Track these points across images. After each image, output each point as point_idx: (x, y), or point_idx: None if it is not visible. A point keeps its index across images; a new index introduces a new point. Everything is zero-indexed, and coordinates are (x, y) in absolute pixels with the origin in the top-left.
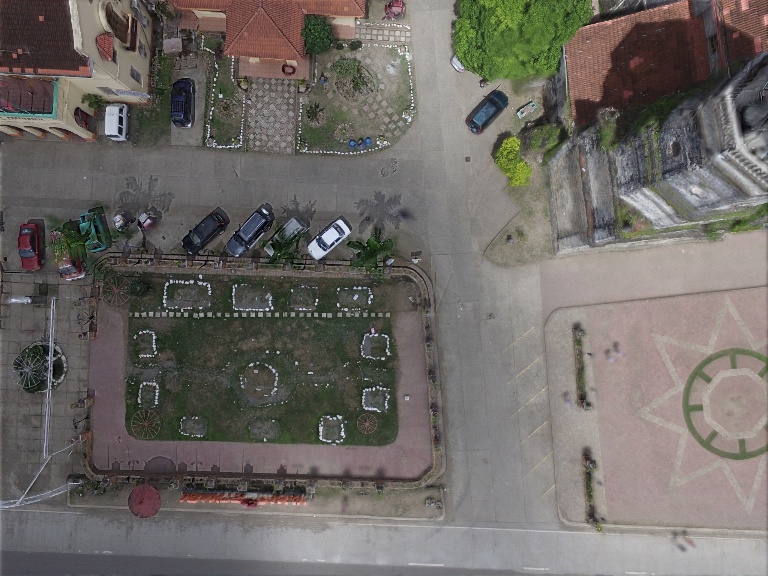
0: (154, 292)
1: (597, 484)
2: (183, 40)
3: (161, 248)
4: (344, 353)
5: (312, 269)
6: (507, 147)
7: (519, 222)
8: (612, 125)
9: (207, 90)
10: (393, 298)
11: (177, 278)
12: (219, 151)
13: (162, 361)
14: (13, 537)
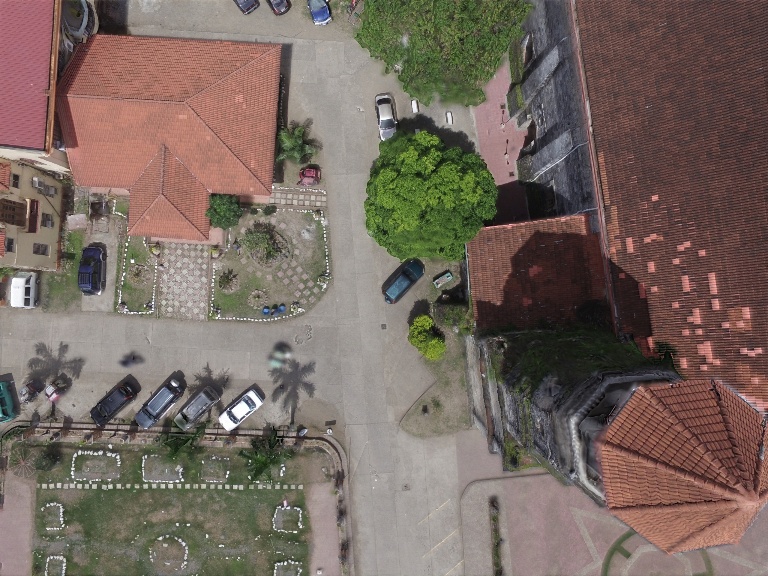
0: (62, 463)
1: None
2: (94, 204)
3: (71, 416)
4: (256, 526)
5: (223, 440)
6: (418, 326)
7: (435, 392)
8: (499, 357)
9: (119, 255)
10: (306, 470)
11: (86, 448)
12: (131, 317)
13: (70, 534)
14: None
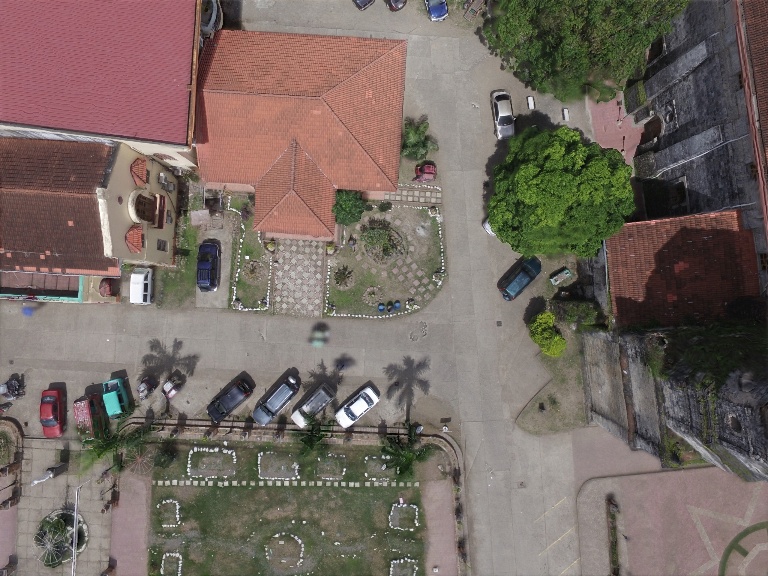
0: (178, 460)
1: None
2: (209, 200)
3: (185, 413)
4: (372, 523)
5: (339, 437)
6: (541, 323)
7: (551, 389)
8: (660, 353)
9: (233, 251)
10: (422, 467)
11: (201, 445)
12: (245, 313)
13: (185, 531)
14: None
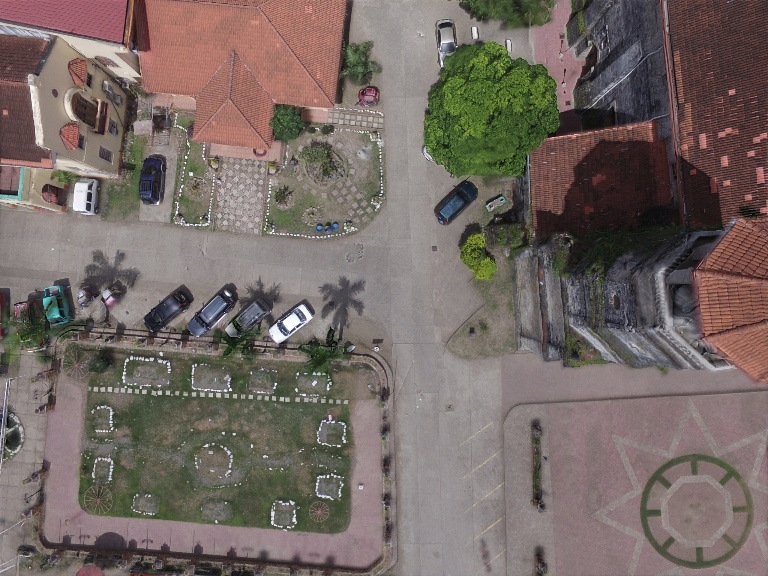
0: (114, 368)
1: None
2: (157, 117)
3: (124, 323)
4: (300, 438)
5: (272, 352)
6: (472, 244)
7: (483, 315)
8: (565, 252)
9: (178, 167)
10: (352, 385)
11: (138, 354)
12: (186, 229)
13: (118, 437)
14: None
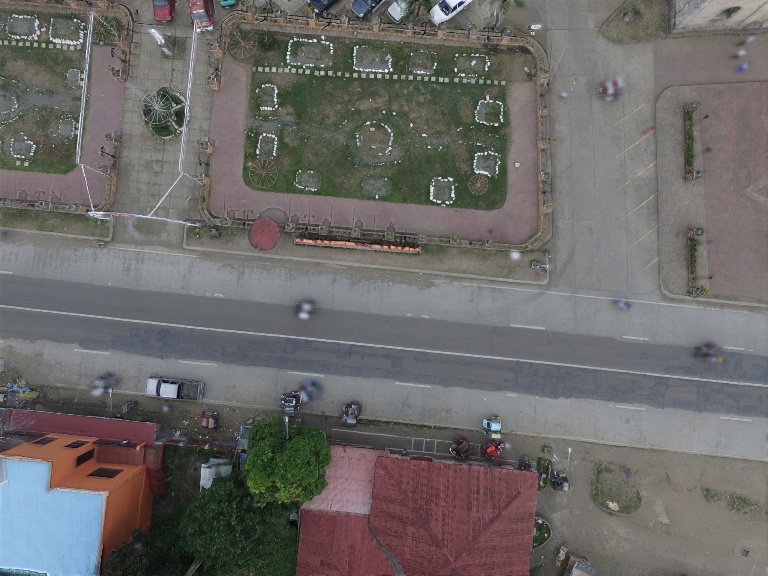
0: (278, 48)
1: (700, 259)
2: None
3: (286, 9)
4: (458, 118)
5: (432, 35)
6: None
7: (636, 1)
8: None
9: None
10: (509, 67)
11: (300, 37)
12: None
13: (282, 115)
14: (129, 275)
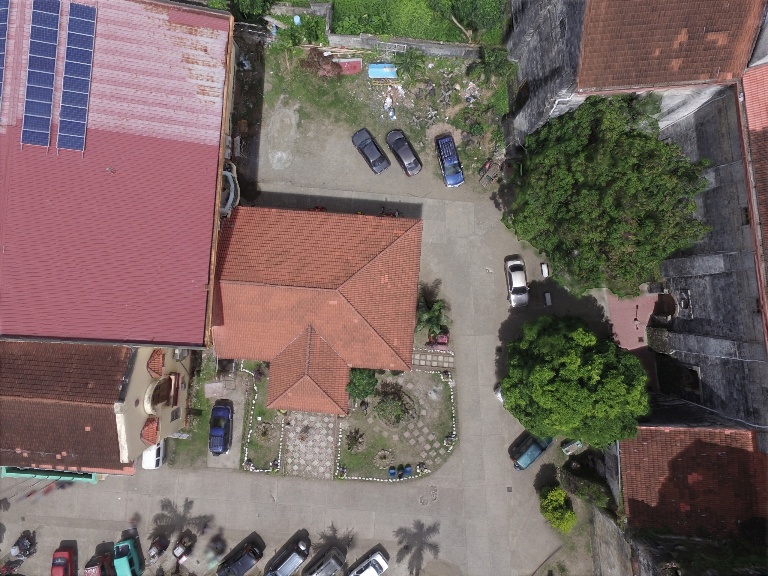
0: None
1: None
2: (222, 360)
3: (195, 573)
4: None
5: None
6: (552, 500)
7: (560, 557)
8: None
9: (245, 412)
10: None
11: None
12: (256, 474)
13: None
14: None
